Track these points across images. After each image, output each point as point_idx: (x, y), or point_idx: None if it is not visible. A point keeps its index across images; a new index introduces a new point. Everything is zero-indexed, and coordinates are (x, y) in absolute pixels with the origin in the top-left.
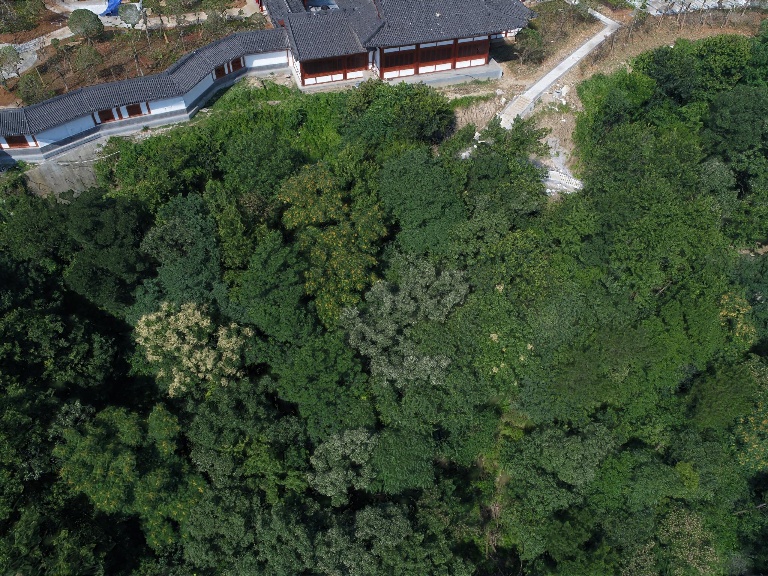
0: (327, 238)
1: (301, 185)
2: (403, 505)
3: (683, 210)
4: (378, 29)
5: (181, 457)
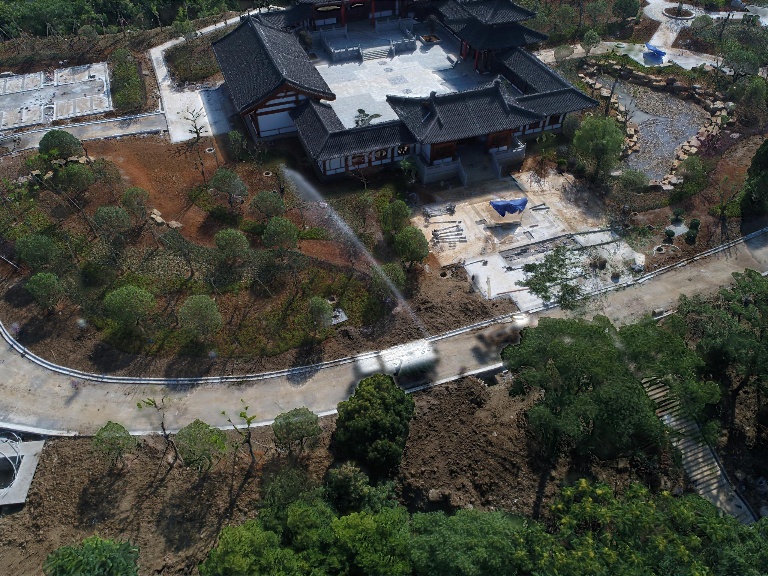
0: None
1: None
2: None
3: None
4: None
5: None
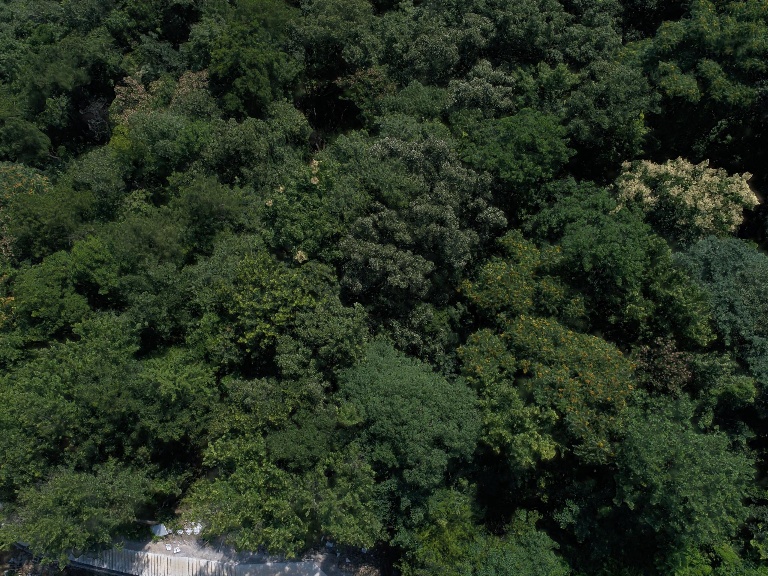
0: (544, 323)
1: (605, 380)
2: (413, 79)
3: (6, 419)
4: None
5: (648, 79)
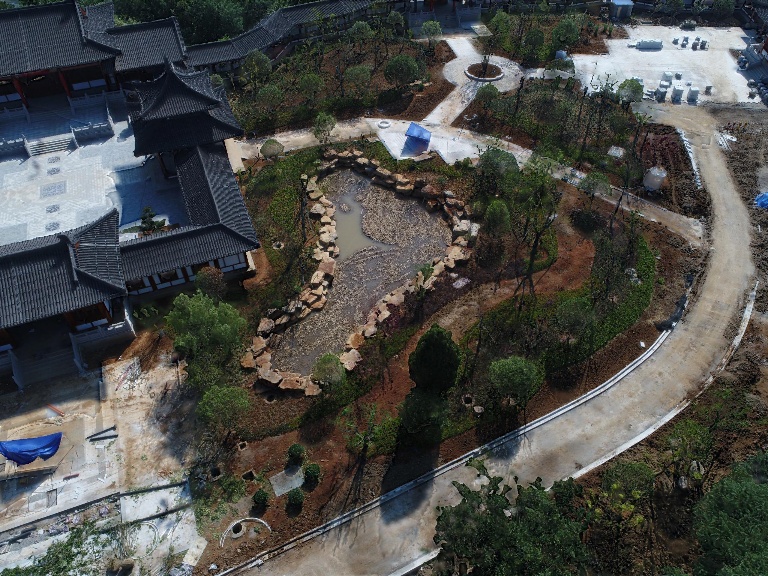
0: None
1: None
2: None
3: None
4: (93, 7)
5: None
